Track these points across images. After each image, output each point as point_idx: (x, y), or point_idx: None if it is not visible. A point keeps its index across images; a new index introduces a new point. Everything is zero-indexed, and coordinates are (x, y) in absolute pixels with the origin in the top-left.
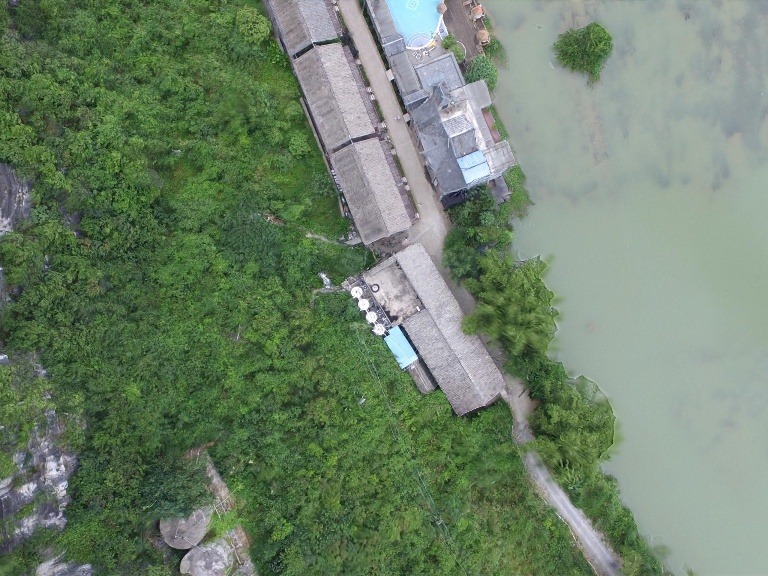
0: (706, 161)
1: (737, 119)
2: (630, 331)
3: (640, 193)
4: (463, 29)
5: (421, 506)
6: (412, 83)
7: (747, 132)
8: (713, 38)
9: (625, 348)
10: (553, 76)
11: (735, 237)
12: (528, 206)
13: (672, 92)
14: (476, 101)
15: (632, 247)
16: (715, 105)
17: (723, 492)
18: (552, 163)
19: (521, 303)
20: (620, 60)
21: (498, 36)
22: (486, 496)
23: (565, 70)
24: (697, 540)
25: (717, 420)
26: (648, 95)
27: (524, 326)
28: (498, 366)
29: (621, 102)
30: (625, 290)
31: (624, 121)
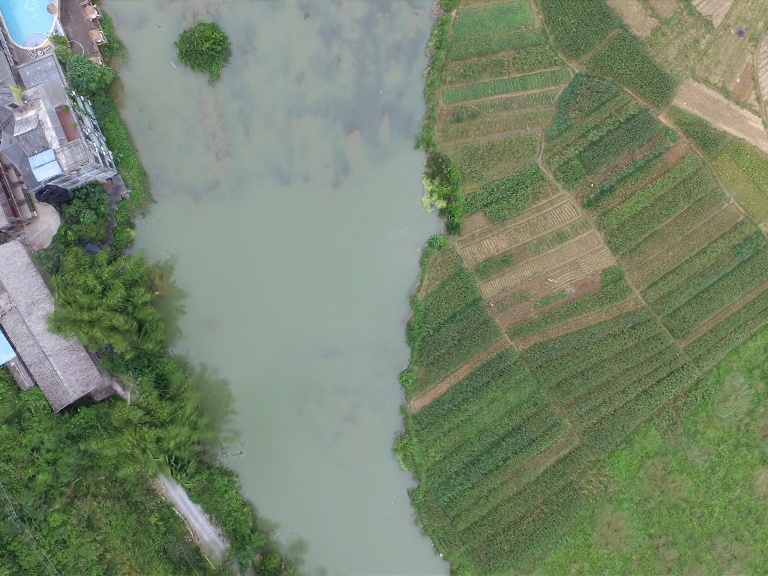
0: (326, 159)
1: (357, 117)
2: (253, 328)
3: (260, 191)
4: (81, 29)
5: (2, 502)
6: (8, 83)
7: (366, 130)
8: (333, 37)
9: (249, 345)
10: (176, 75)
11: (355, 234)
12: (151, 204)
13: (292, 90)
14: (50, 100)
15: (256, 244)
16: (335, 103)
17: (346, 487)
18: (175, 161)
19: (87, 300)
20: (241, 59)
21: (121, 36)
22: (92, 492)
23: (188, 69)
24: (322, 535)
25: (338, 416)
26: (269, 93)
27: (96, 323)
28: (96, 363)
29: (243, 100)
30: (250, 287)
31: (245, 119)
